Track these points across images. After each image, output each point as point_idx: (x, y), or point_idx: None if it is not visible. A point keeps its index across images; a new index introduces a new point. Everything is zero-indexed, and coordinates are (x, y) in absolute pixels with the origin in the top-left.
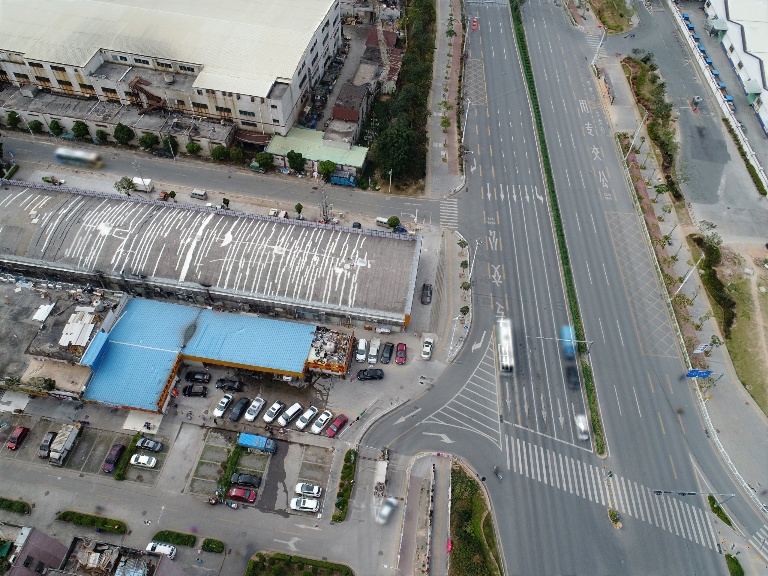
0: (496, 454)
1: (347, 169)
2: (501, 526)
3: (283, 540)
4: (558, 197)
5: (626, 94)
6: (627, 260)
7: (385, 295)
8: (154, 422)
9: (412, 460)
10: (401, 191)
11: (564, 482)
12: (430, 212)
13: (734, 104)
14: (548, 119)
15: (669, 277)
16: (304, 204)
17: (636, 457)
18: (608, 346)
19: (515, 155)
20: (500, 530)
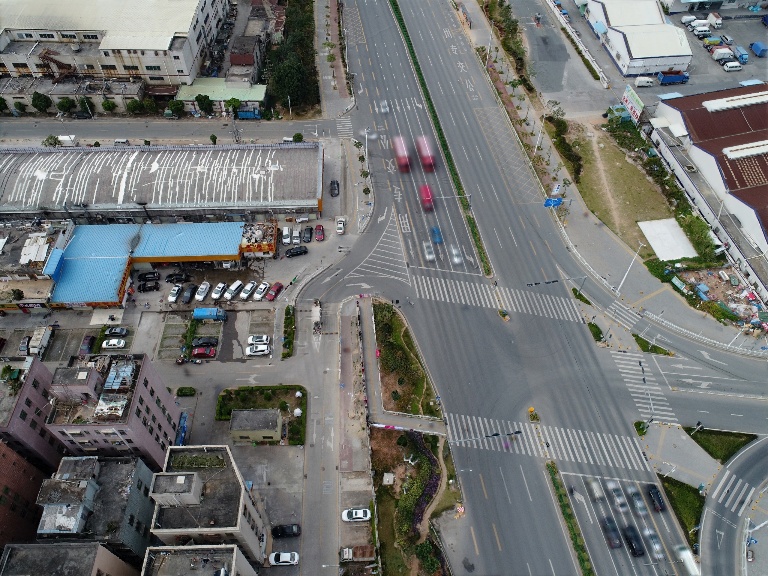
0: (407, 289)
1: (251, 104)
2: (417, 335)
3: (244, 378)
4: (434, 103)
5: (481, 20)
6: (495, 141)
7: (298, 189)
8: (117, 315)
9: (340, 305)
10: (301, 116)
11: (462, 298)
12: (328, 129)
13: (569, 16)
14: (419, 46)
15: (527, 145)
16: (218, 138)
17: (516, 273)
18: (486, 202)
19: (394, 77)
20: (417, 338)
